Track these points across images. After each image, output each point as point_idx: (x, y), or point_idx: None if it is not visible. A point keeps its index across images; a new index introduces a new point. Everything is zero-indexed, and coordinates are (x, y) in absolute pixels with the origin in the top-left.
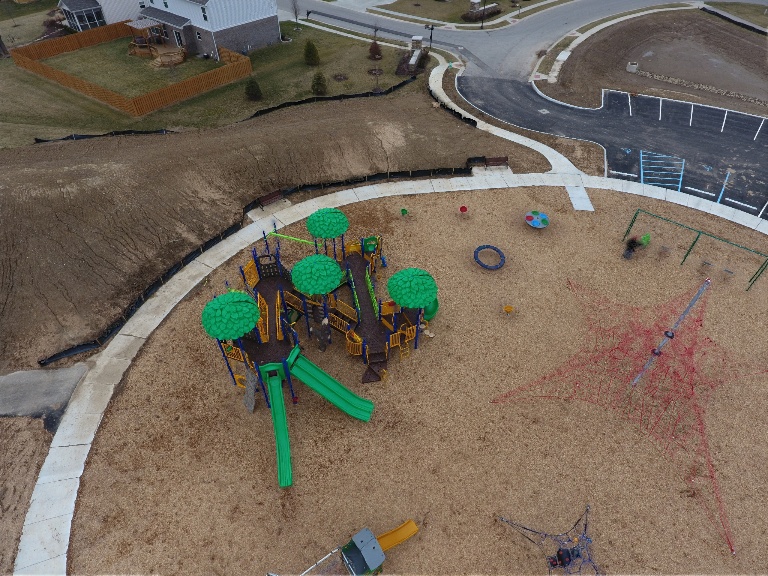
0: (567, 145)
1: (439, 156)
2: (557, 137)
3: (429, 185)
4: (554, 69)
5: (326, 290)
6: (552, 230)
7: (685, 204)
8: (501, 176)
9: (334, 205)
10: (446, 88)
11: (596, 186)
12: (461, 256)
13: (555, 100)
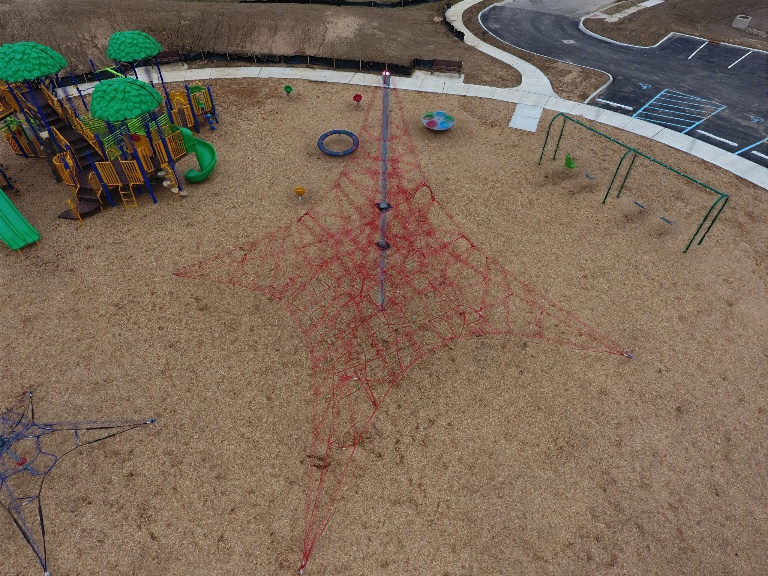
0: (562, 69)
1: (385, 54)
2: (558, 61)
3: (349, 77)
4: (625, 11)
5: (17, 78)
6: (454, 138)
7: (678, 146)
8: (444, 82)
9: (227, 76)
10: (468, 11)
11: (561, 109)
12: (311, 138)
13: (594, 33)
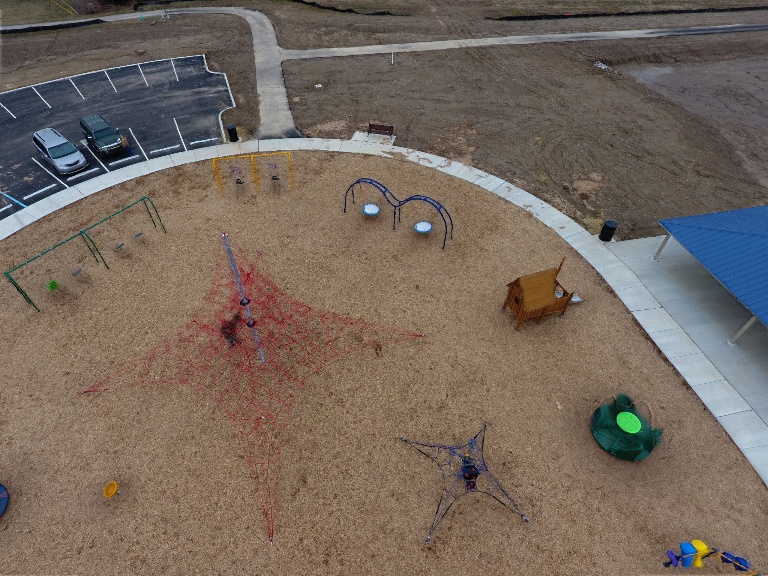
0: None
1: None
2: None
3: None
4: None
5: None
6: None
7: (9, 233)
8: None
9: None
10: None
11: None
12: None
13: None
